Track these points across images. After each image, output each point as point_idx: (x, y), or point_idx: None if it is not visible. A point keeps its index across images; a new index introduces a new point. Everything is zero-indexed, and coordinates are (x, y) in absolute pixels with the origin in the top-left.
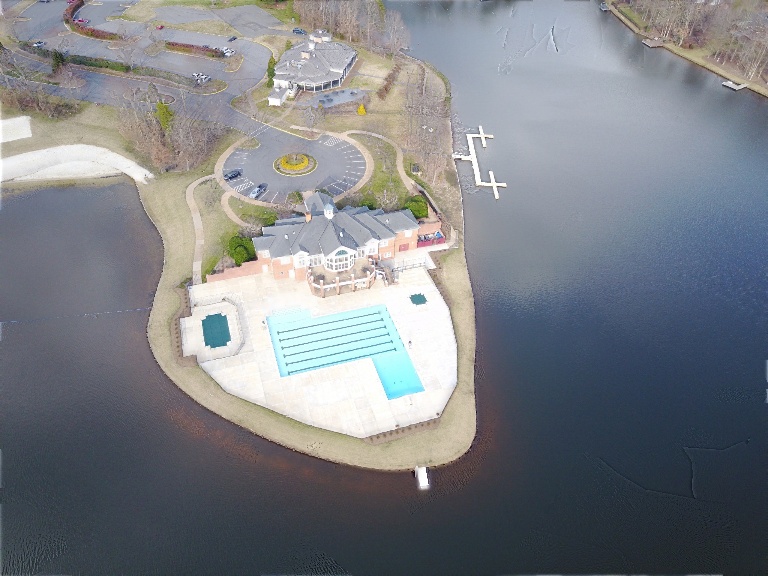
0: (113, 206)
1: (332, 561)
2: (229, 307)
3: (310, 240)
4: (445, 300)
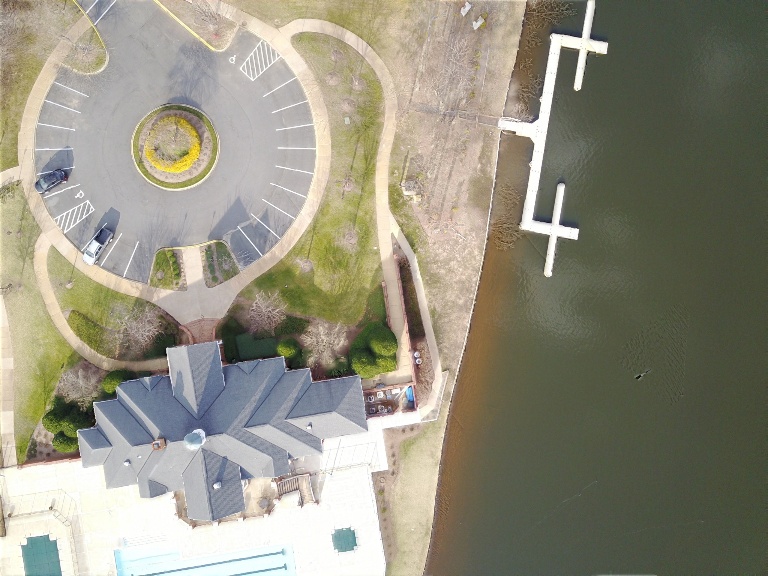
0: None
1: None
2: (60, 524)
3: (167, 473)
4: (384, 546)
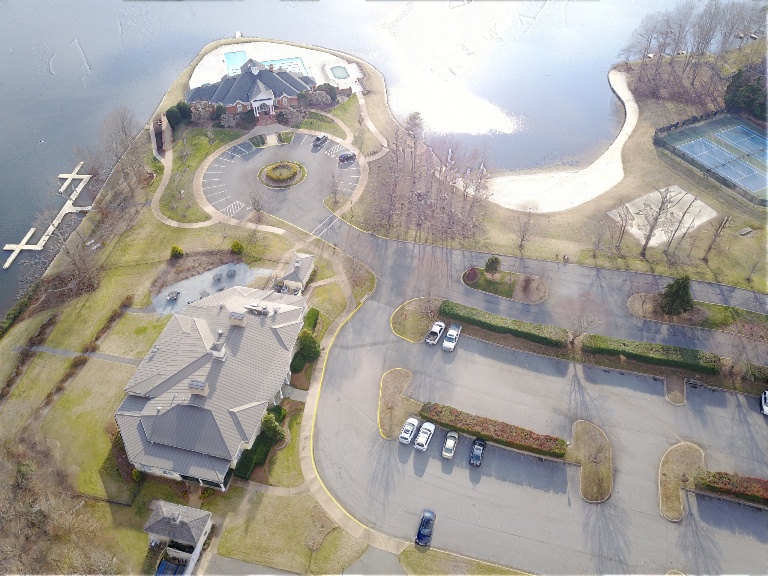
0: (458, 154)
1: (280, 3)
2: None
3: None
4: None
